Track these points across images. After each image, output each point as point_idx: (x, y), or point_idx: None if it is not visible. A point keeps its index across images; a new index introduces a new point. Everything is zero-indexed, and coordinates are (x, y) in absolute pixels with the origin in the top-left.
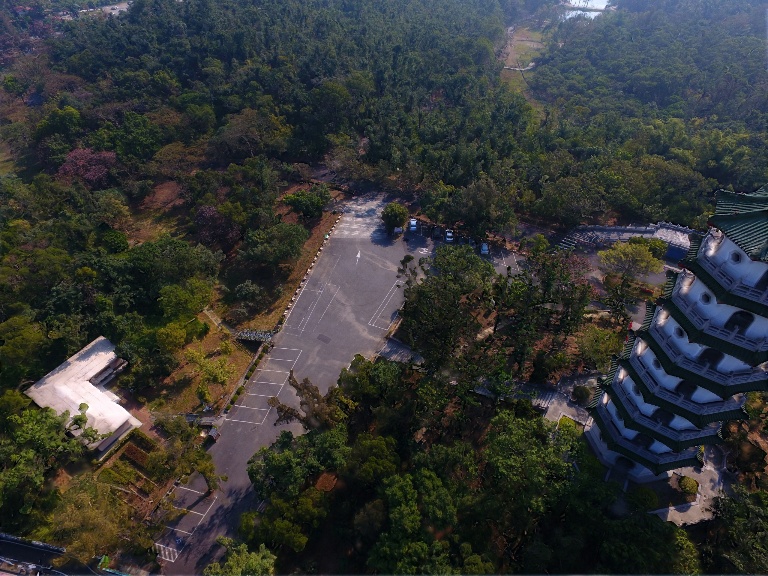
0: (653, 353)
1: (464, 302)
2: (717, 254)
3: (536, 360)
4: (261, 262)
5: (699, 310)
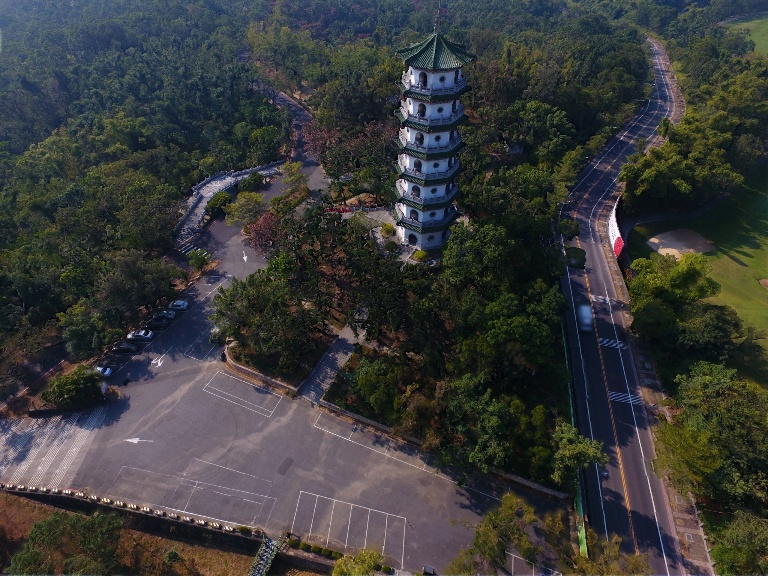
0: (432, 163)
1: None
2: (435, 85)
3: None
4: None
5: (444, 116)
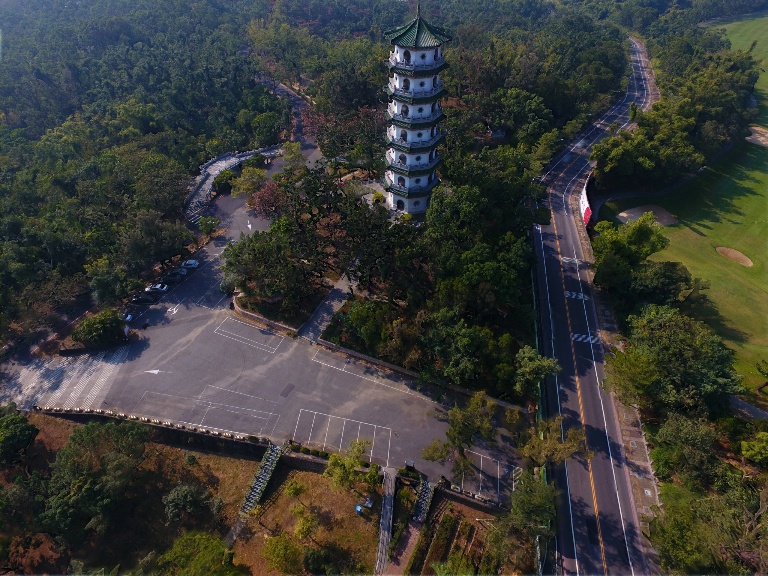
0: None
1: None
2: (417, 61)
3: None
4: (124, 491)
5: (426, 90)
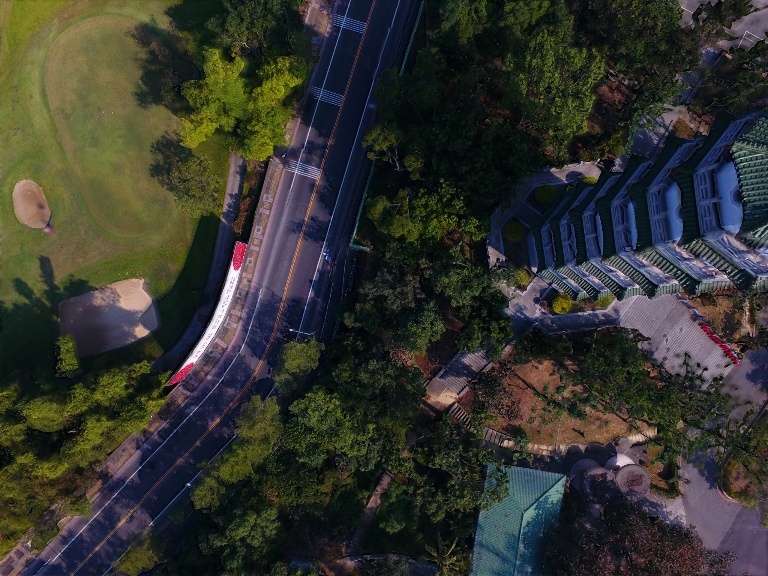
0: None
1: None
2: None
3: None
4: None
5: None
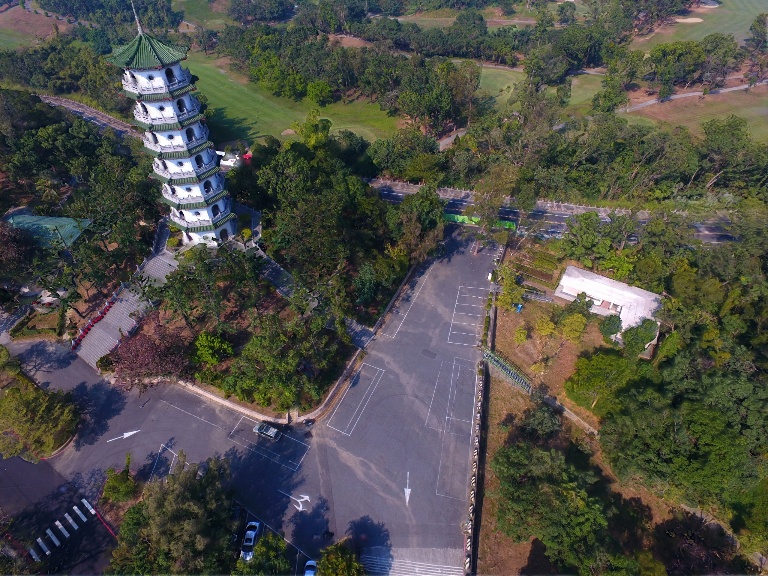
0: None
1: None
2: None
3: None
4: None
5: None
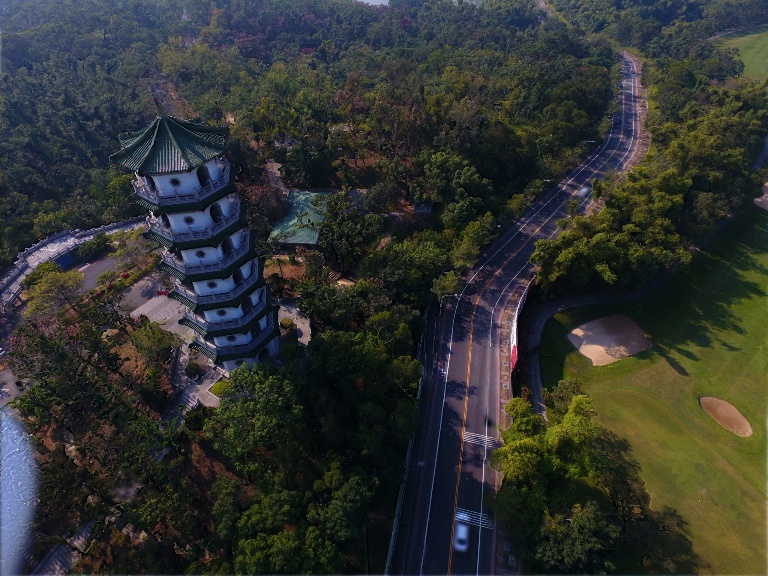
0: (203, 283)
1: (3, 478)
2: (164, 190)
3: (144, 397)
4: None
5: (196, 229)
